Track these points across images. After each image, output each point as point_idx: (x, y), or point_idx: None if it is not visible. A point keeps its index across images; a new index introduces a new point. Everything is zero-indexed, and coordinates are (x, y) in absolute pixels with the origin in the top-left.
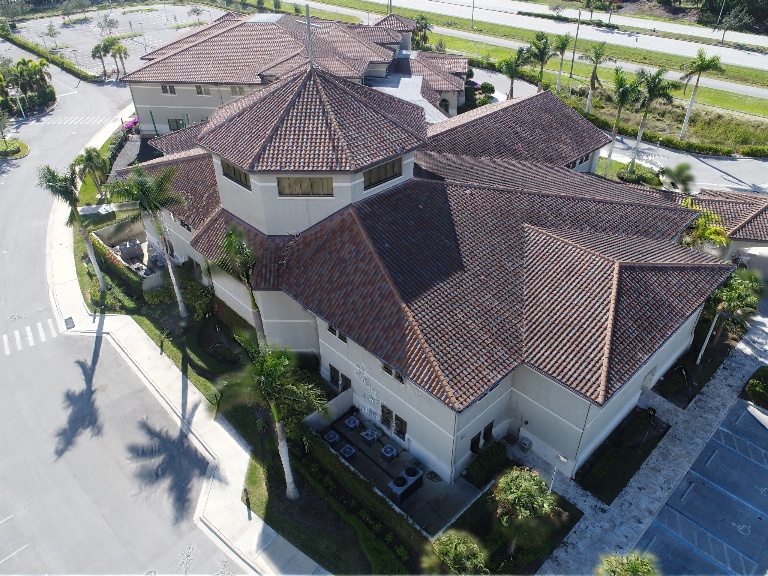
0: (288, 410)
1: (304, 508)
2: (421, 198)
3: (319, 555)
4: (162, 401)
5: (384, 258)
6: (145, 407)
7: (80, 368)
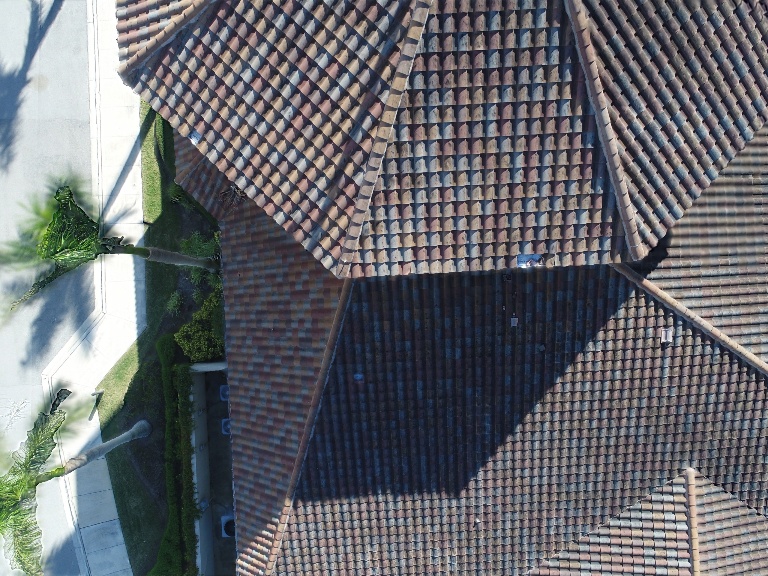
0: (210, 313)
1: (139, 458)
2: (538, 301)
3: (124, 510)
4: (94, 166)
5: (328, 402)
6: (71, 161)
7: (29, 17)
